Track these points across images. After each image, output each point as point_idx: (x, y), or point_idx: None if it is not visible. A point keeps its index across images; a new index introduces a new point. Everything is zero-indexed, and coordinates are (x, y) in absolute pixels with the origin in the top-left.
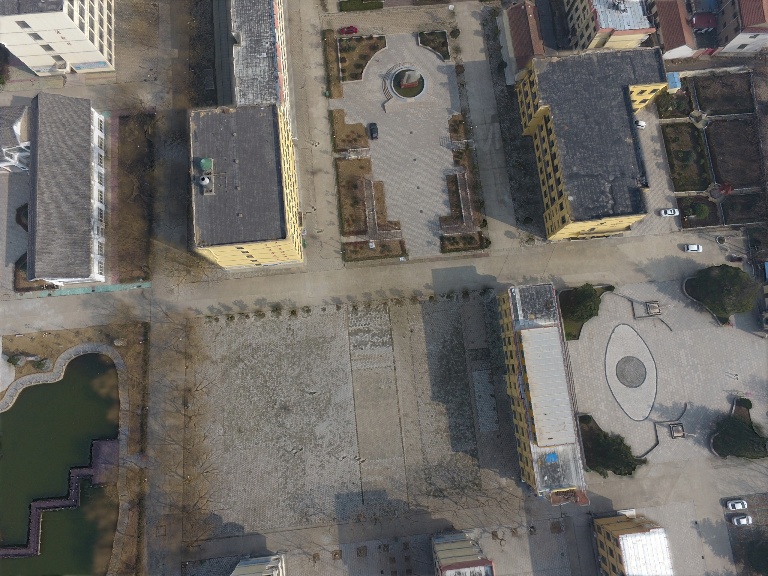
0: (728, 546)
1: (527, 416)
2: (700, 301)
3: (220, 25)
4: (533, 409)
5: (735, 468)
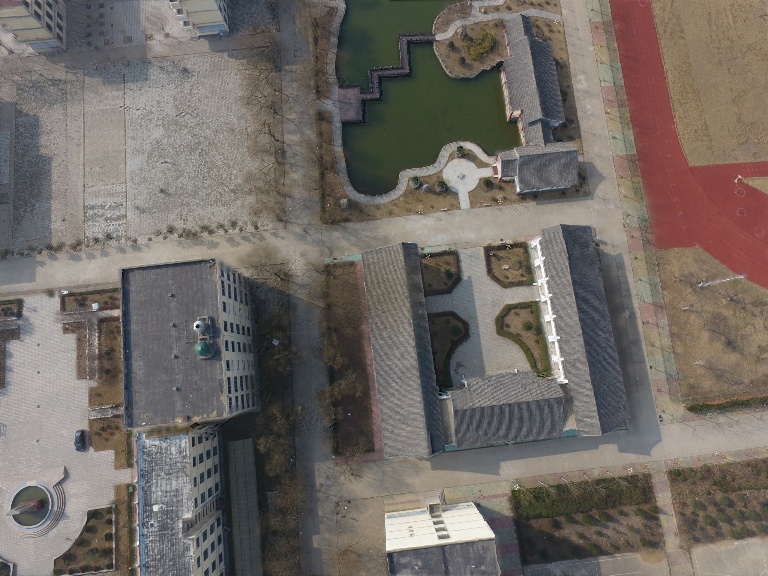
0: None
1: None
2: None
3: None
4: None
5: None
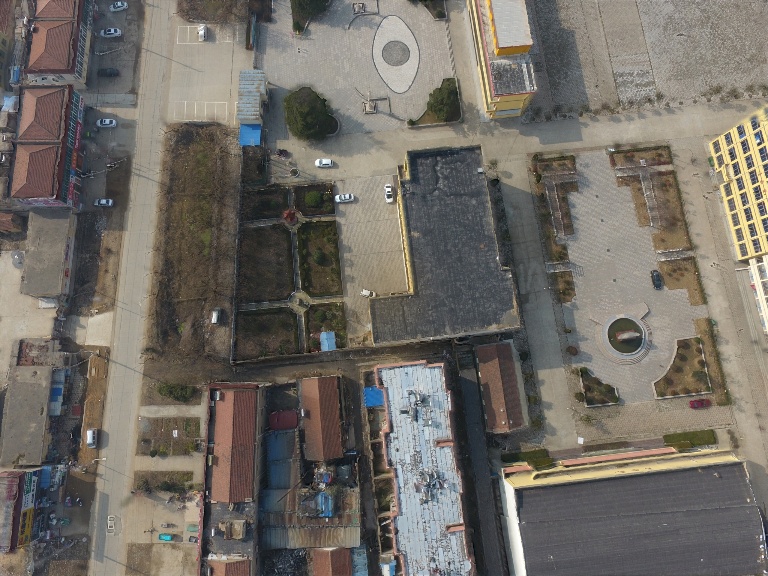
0: None
1: None
2: None
3: None
4: None
5: None
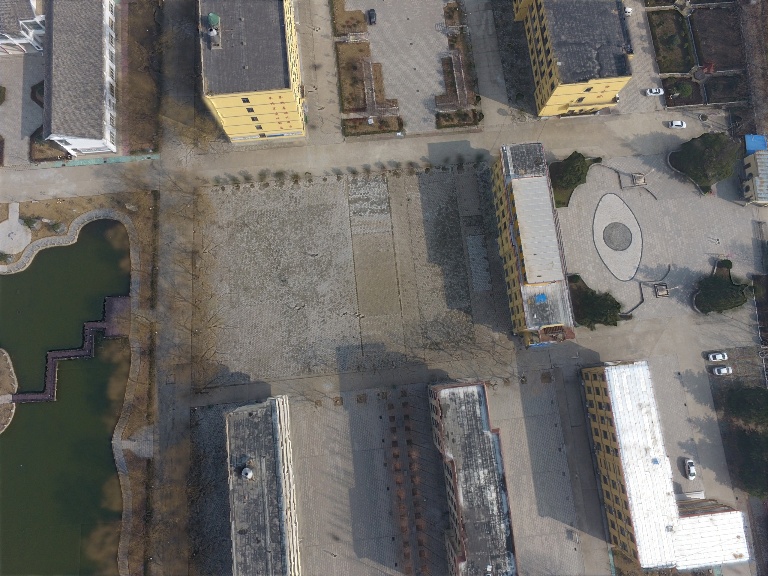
0: (709, 395)
1: (518, 261)
2: (683, 172)
3: None
4: (523, 250)
5: (716, 324)
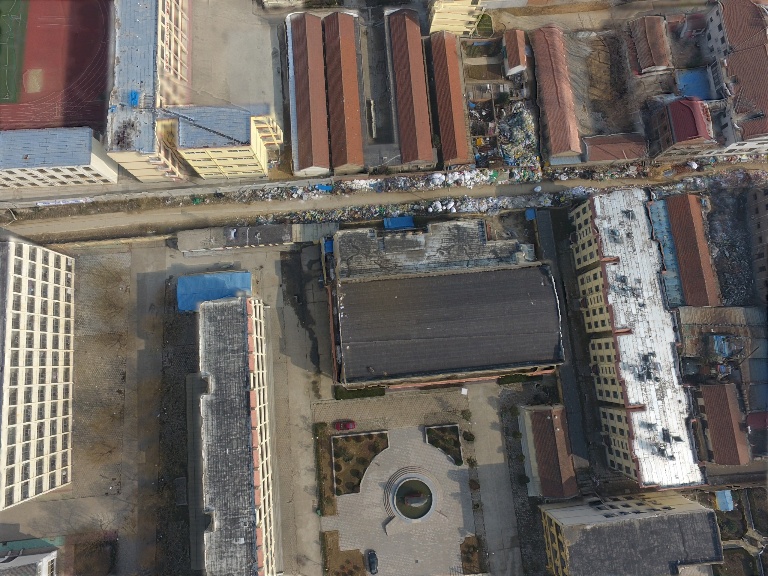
0: None
1: None
2: None
3: (194, 435)
4: None
5: None
